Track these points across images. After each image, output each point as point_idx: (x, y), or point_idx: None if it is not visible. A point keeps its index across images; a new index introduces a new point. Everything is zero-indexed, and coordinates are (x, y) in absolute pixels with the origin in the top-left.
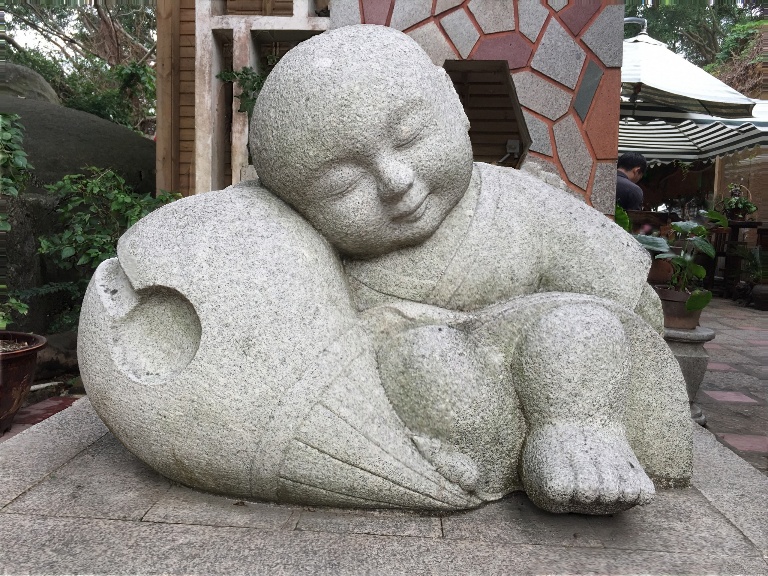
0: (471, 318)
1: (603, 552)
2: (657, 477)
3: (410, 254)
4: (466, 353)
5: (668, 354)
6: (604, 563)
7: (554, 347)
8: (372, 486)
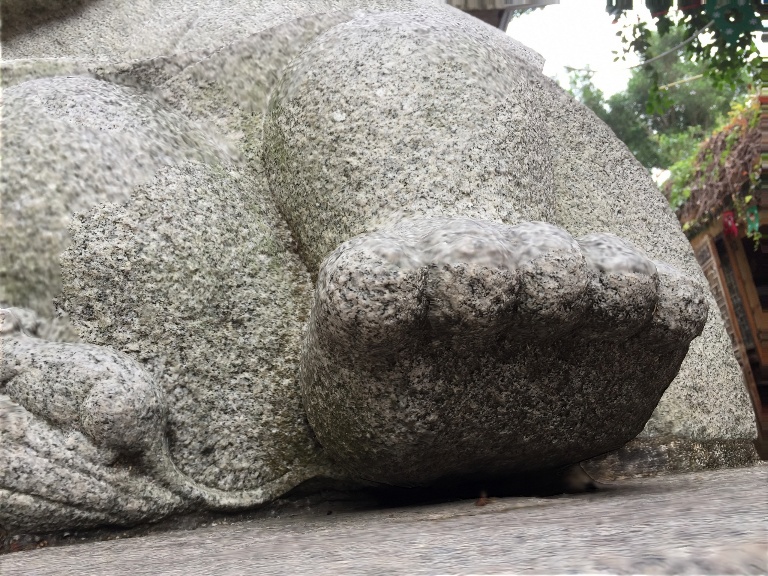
0: (152, 58)
1: None
2: (681, 439)
3: (55, 32)
4: (127, 104)
5: (620, 151)
6: None
7: (344, 54)
8: None
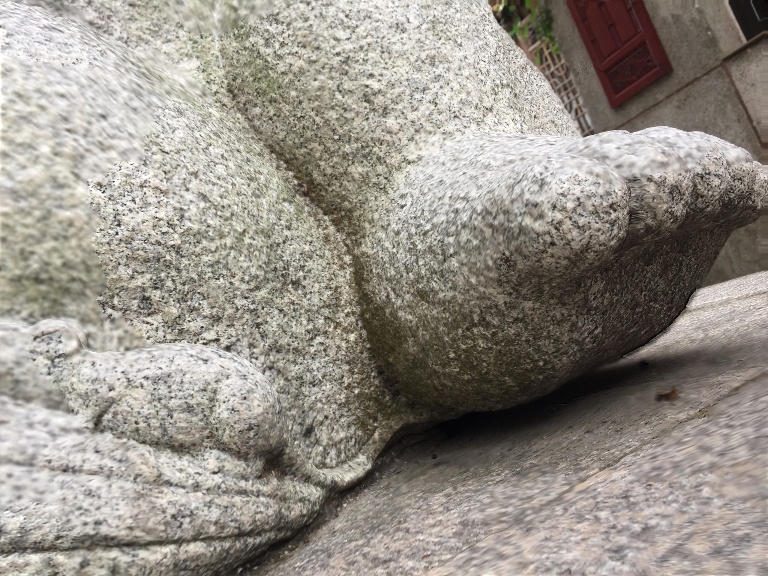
0: None
1: None
2: None
3: None
4: (66, 29)
5: (522, 58)
6: None
7: None
8: None
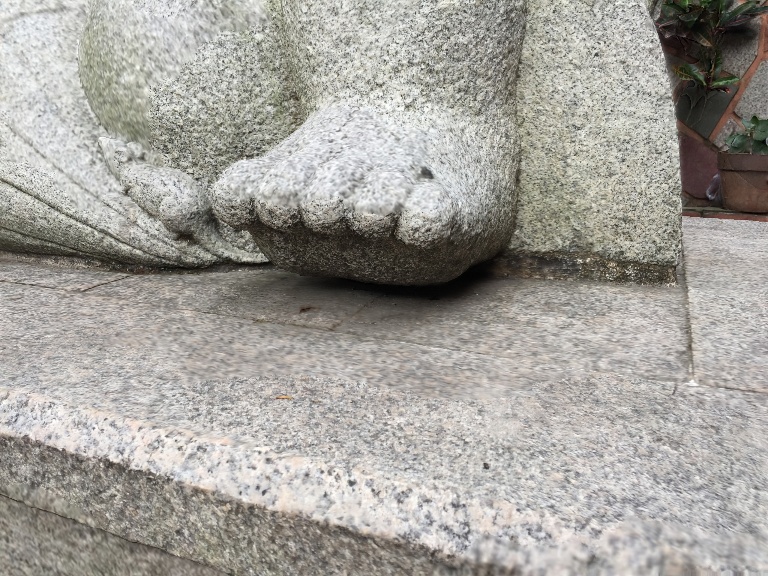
0: None
1: (309, 333)
2: (598, 257)
3: None
4: None
5: None
6: (277, 346)
7: None
8: (20, 210)
